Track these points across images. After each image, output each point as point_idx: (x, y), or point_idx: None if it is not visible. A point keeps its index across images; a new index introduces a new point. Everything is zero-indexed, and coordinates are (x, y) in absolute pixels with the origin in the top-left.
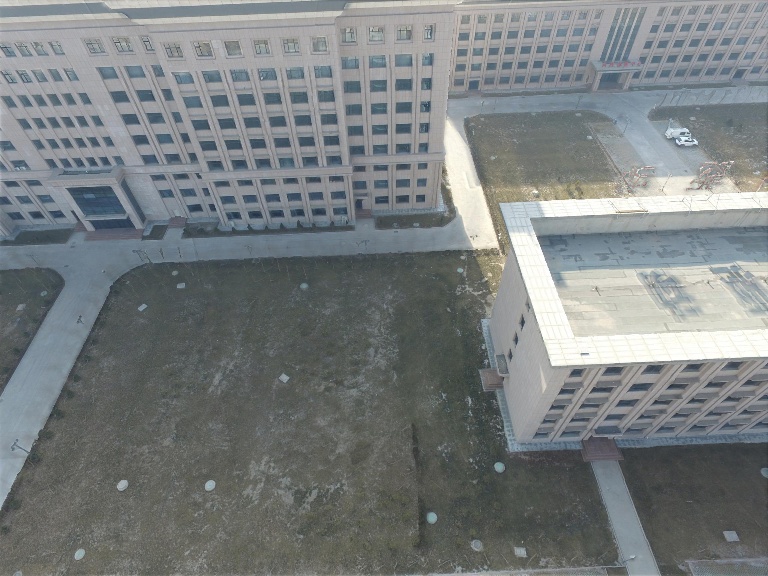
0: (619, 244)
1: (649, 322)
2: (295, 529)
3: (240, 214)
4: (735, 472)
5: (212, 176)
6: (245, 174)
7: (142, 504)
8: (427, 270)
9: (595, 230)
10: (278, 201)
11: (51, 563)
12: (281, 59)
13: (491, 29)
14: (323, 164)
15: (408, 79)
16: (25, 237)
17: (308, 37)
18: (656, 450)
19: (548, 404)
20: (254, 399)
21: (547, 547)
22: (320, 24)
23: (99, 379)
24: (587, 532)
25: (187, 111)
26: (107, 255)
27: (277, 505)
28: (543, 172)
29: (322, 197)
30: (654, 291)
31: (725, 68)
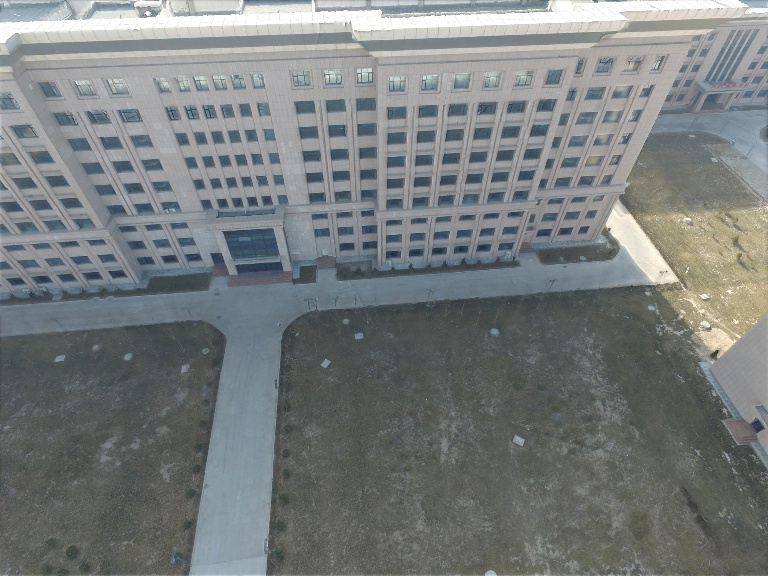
0: None
1: None
2: None
3: (401, 252)
4: None
5: (388, 215)
6: (424, 212)
7: None
8: (617, 309)
9: None
10: (445, 238)
11: None
12: (509, 92)
13: None
14: (508, 200)
15: (618, 111)
16: (158, 284)
17: (546, 69)
18: None
19: None
20: (496, 467)
21: None
22: (563, 56)
23: (310, 453)
24: None
25: (387, 148)
26: (261, 303)
27: None
28: (685, 198)
29: (492, 233)
30: None
31: None
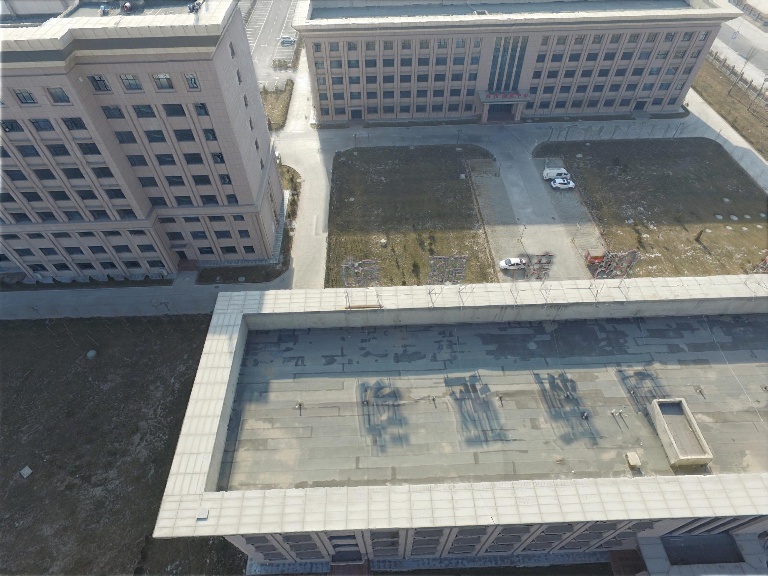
0: (356, 342)
1: (339, 455)
2: None
3: (45, 266)
4: None
5: None
6: (30, 227)
7: None
8: None
9: (332, 324)
10: (82, 253)
11: None
12: (19, 110)
13: (364, 57)
14: (116, 218)
15: (187, 129)
16: None
17: (41, 87)
18: (413, 574)
19: (243, 541)
20: None
21: None
22: (50, 74)
23: None
24: None
25: None
26: None
27: None
28: (400, 217)
29: (130, 250)
30: (366, 410)
31: (624, 99)
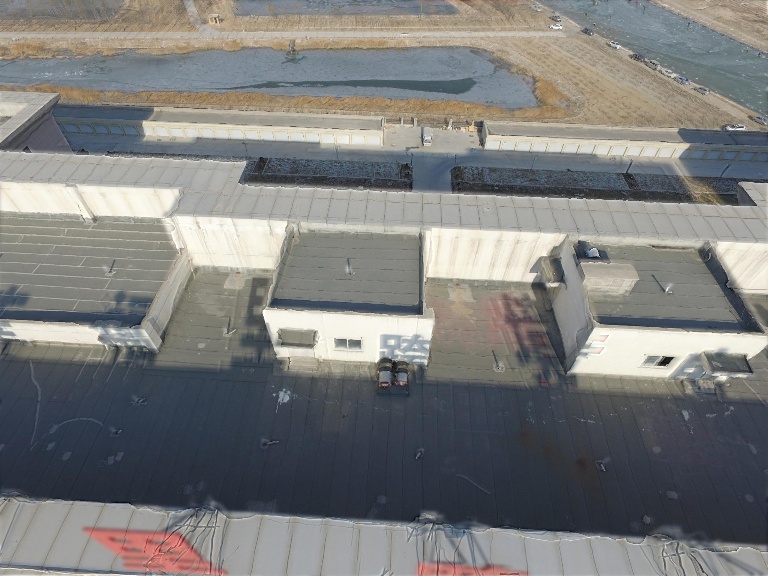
0: None
1: None
2: None
3: None
4: None
5: None
6: None
7: None
8: None
9: None
10: None
11: (374, 186)
12: None
13: None
14: None
15: None
16: None
17: None
18: None
19: None
20: None
21: None
22: None
23: None
24: None
25: None
26: None
27: None
28: None
29: None
30: None
31: None
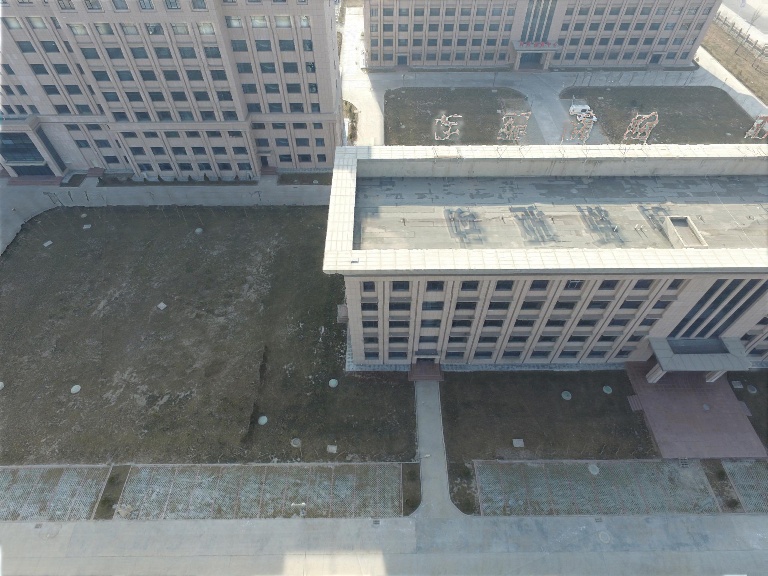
0: (440, 186)
1: (437, 247)
2: (141, 425)
3: (151, 166)
4: (539, 394)
5: (119, 126)
6: (149, 126)
7: (13, 402)
8: (315, 221)
9: (421, 174)
10: (185, 154)
11: None
12: (165, 15)
13: (413, 6)
14: (220, 119)
15: (290, 40)
16: None
17: None
18: (475, 374)
19: (358, 320)
20: (131, 322)
21: (356, 446)
22: None
23: None
24: (394, 435)
25: (86, 62)
26: (25, 198)
27: (131, 406)
28: (446, 141)
29: (226, 152)
30: (453, 224)
31: (641, 53)
